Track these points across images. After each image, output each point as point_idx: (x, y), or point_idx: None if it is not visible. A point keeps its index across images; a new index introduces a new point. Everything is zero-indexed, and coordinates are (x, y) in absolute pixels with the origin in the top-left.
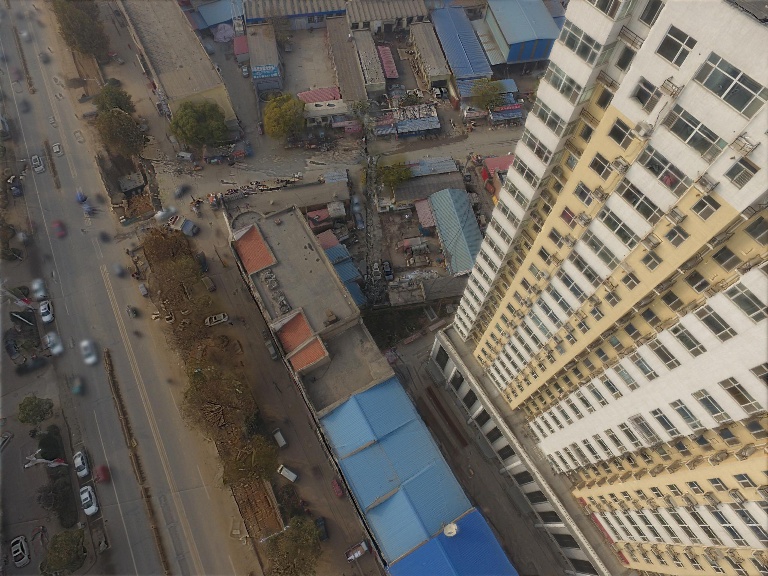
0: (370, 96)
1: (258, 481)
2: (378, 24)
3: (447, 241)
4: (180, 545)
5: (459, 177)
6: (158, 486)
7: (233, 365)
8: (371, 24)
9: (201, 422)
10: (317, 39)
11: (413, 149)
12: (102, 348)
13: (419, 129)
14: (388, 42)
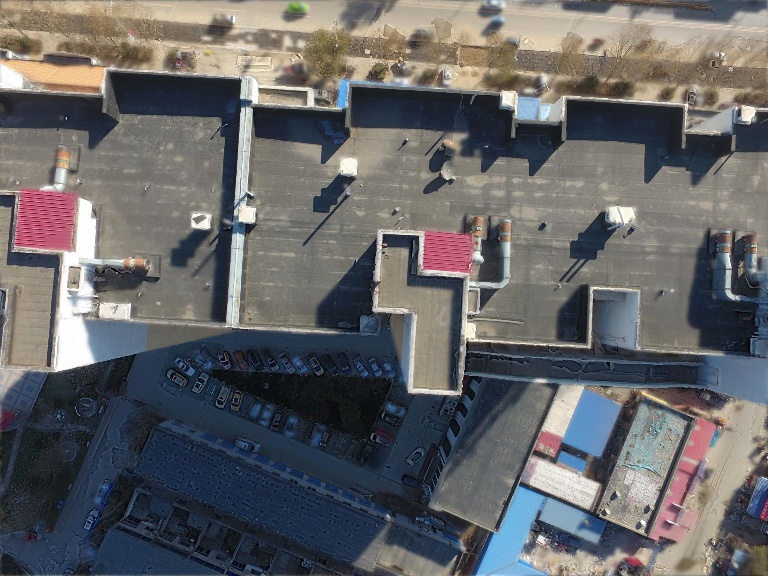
0: None
1: (548, 71)
2: None
3: None
4: (540, 7)
5: None
6: (586, 8)
7: (644, 91)
8: None
9: (619, 37)
10: None
11: None
12: (717, 8)
13: None
14: None
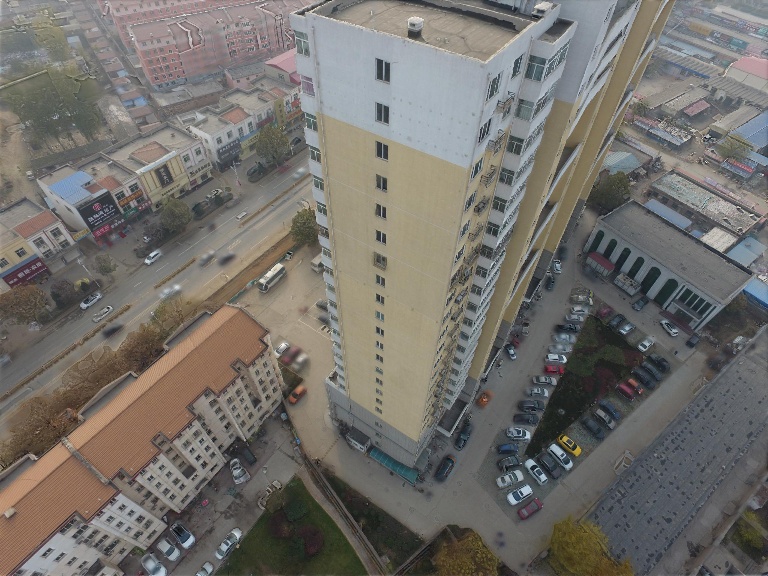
0: (660, 112)
1: None
2: (722, 94)
3: None
4: None
5: (647, 158)
6: None
7: None
8: (717, 91)
9: None
10: (674, 83)
11: (647, 144)
12: None
13: (664, 137)
14: (718, 108)
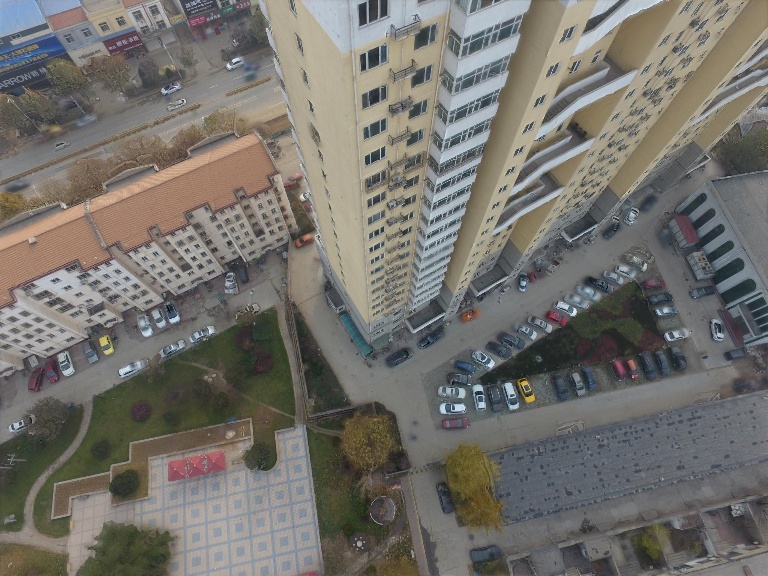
0: None
1: None
2: None
3: (762, 111)
4: None
5: None
6: None
7: None
8: None
9: None
10: None
11: None
12: None
13: None
14: None
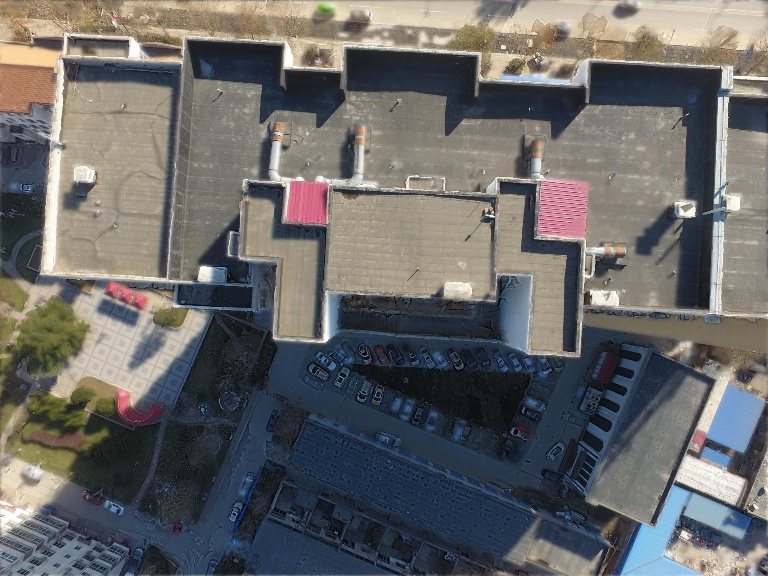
0: None
1: None
2: None
3: None
4: (678, 0)
5: None
6: (724, 1)
7: None
8: None
9: None
10: None
11: None
12: None
13: None
14: None
